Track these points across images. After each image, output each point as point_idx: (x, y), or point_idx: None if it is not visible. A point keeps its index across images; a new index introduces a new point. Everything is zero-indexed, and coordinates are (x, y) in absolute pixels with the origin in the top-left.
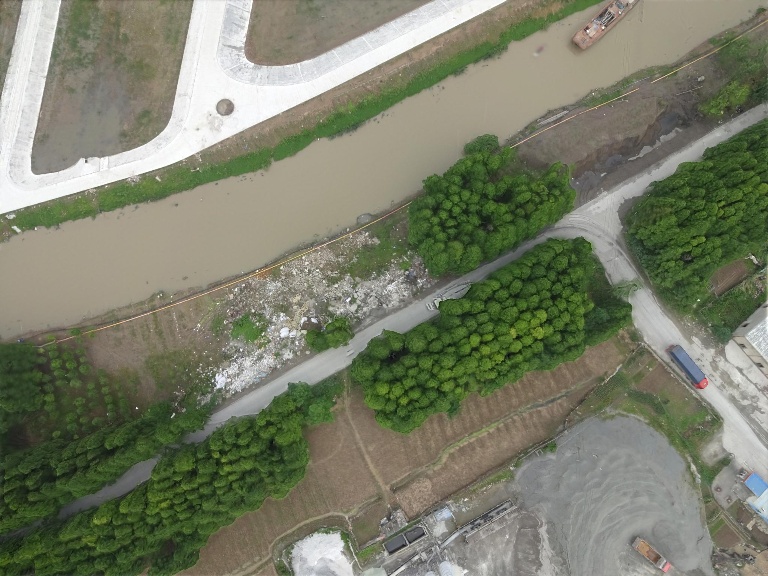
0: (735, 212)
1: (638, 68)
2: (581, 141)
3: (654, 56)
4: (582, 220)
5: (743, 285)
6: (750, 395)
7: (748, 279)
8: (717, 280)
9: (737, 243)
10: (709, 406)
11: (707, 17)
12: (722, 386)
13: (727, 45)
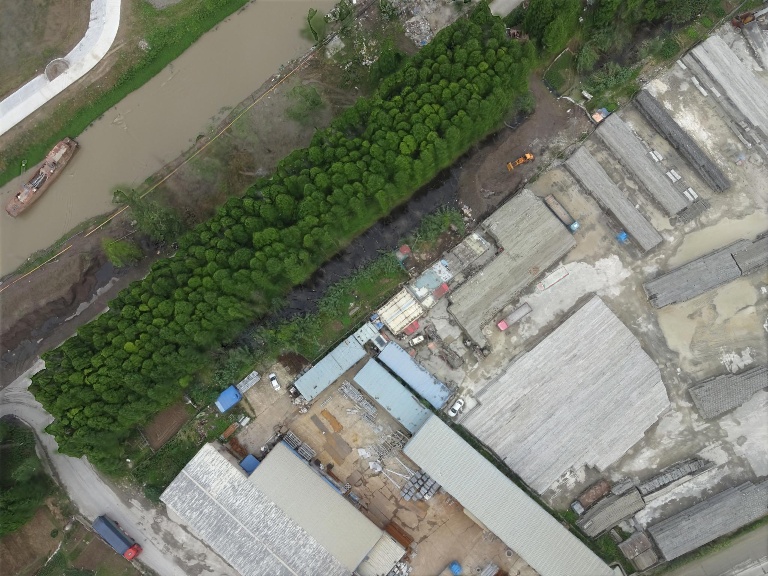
0: (97, 379)
1: (78, 222)
2: (6, 313)
3: (96, 206)
4: (18, 393)
5: (181, 434)
6: (197, 553)
7: (183, 428)
8: (156, 433)
9: (115, 408)
10: (151, 573)
11: (156, 153)
12: (165, 548)
13: (162, 182)
